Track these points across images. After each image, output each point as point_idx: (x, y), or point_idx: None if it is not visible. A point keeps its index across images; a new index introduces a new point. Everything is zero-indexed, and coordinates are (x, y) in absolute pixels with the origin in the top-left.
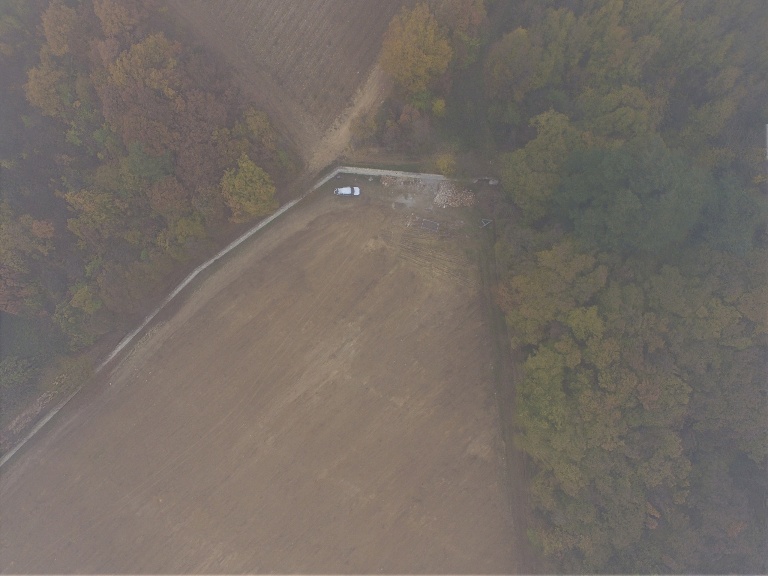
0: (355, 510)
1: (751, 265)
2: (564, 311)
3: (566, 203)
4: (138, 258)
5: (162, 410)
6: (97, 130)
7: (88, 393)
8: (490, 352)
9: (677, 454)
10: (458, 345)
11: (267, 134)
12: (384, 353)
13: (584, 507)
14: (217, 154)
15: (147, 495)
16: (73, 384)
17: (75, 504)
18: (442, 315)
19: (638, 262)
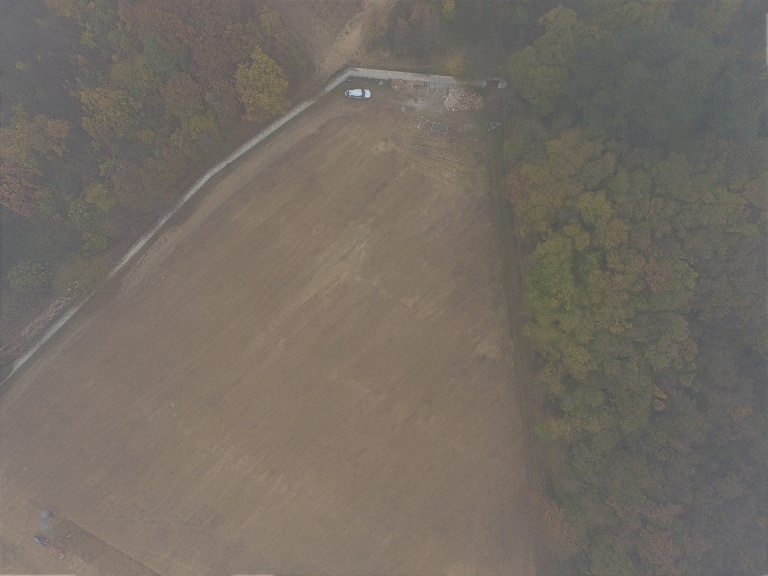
0: (365, 411)
1: (756, 153)
2: (573, 195)
3: (574, 95)
4: (152, 155)
5: (174, 315)
6: (111, 31)
7: (101, 299)
8: (499, 253)
9: (684, 337)
10: (467, 246)
11: (280, 32)
12: (394, 254)
13: (592, 391)
14: (231, 48)
15: (159, 399)
16: (86, 289)
17: (87, 409)
18: (451, 216)
19: (645, 149)
